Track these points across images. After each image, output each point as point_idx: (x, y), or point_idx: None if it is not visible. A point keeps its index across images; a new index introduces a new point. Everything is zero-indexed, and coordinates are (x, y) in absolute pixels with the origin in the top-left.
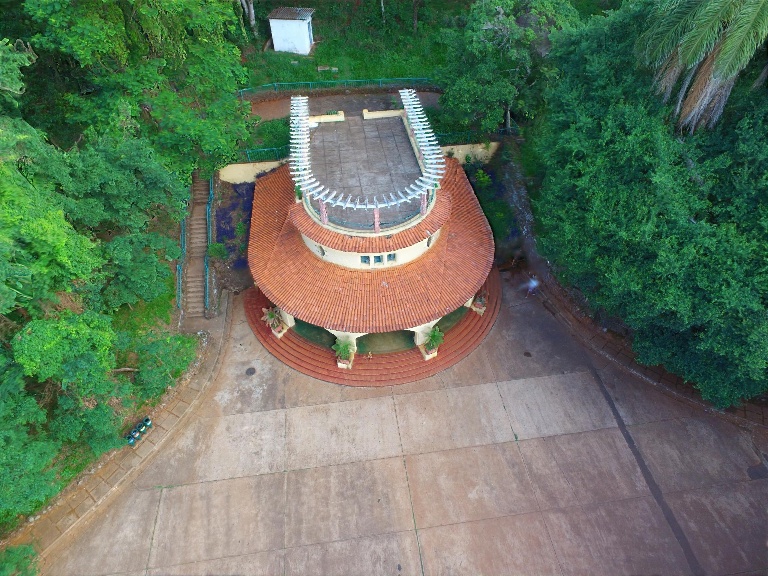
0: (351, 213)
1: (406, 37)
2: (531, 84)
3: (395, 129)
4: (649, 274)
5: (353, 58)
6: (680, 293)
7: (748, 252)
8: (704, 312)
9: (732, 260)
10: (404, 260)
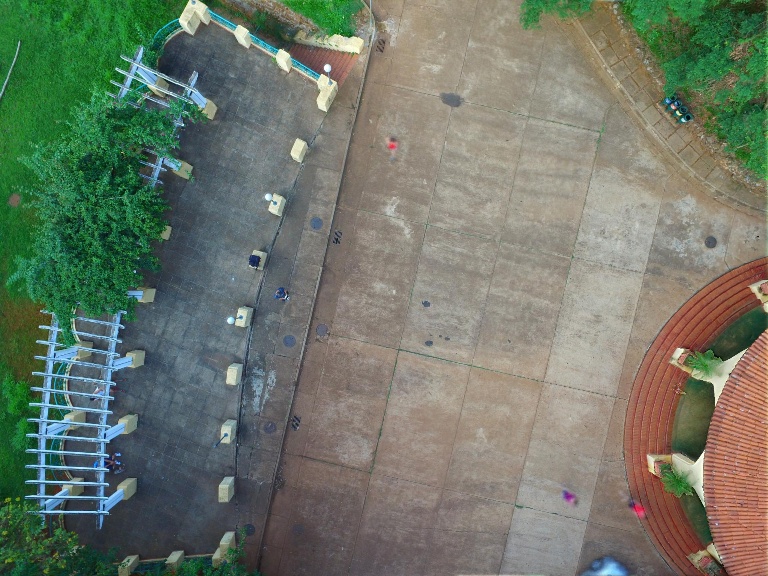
0: None
1: None
2: None
3: None
4: None
5: None
6: None
7: None
8: None
9: None
10: None
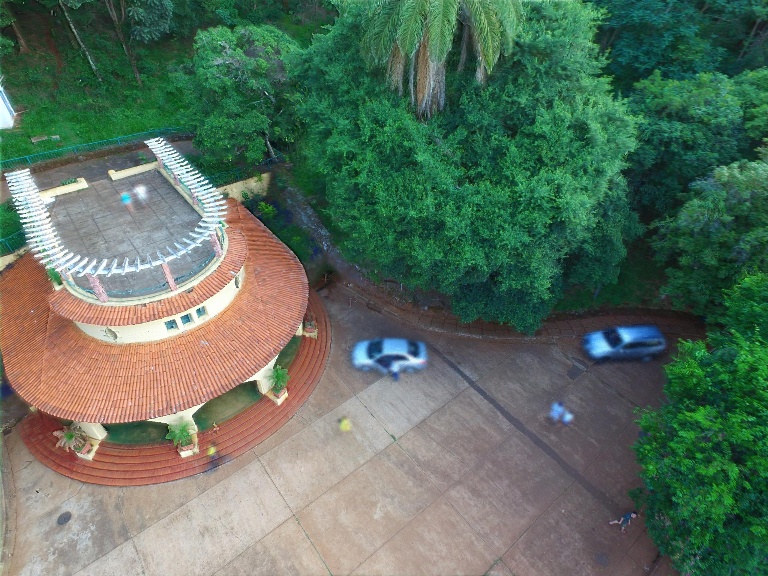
0: (134, 280)
1: (132, 92)
2: (279, 112)
3: (154, 182)
4: (444, 242)
5: (75, 122)
6: (473, 248)
7: (506, 198)
8: (495, 258)
9: (498, 208)
10: (216, 310)
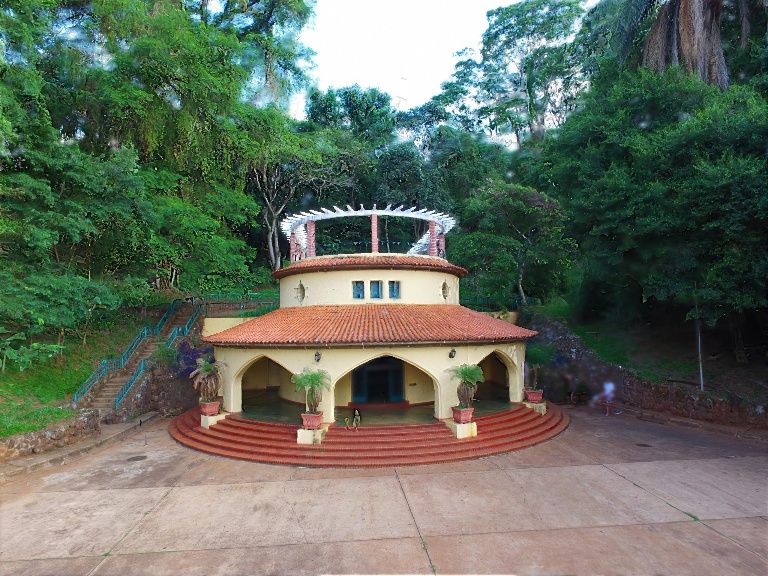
0: None
1: None
2: None
3: None
4: None
5: None
6: None
7: None
8: None
9: None
10: (412, 299)
